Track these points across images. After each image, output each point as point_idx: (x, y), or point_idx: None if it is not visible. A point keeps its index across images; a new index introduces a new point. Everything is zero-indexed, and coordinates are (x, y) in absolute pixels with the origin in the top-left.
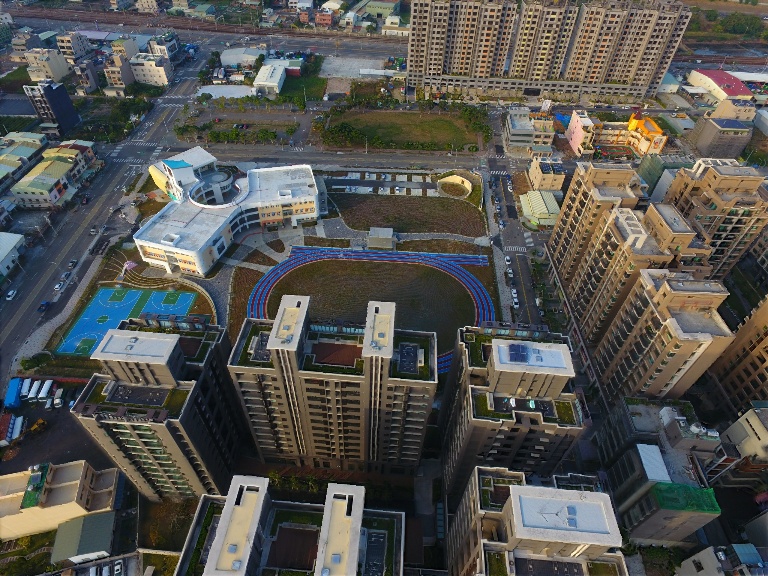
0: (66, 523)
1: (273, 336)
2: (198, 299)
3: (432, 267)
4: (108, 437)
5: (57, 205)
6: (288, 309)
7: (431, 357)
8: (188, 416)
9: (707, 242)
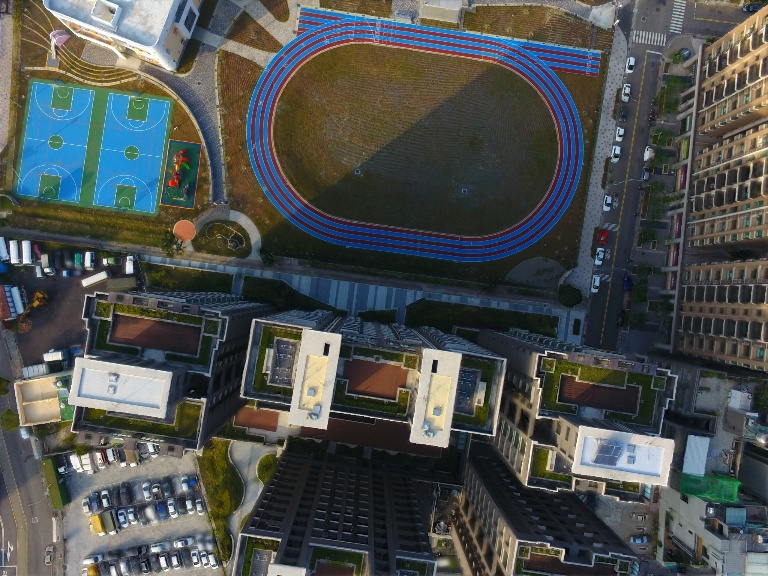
0: None
1: (295, 406)
2: (176, 113)
3: (513, 71)
4: None
5: None
6: (312, 357)
7: (493, 389)
8: (206, 429)
9: None
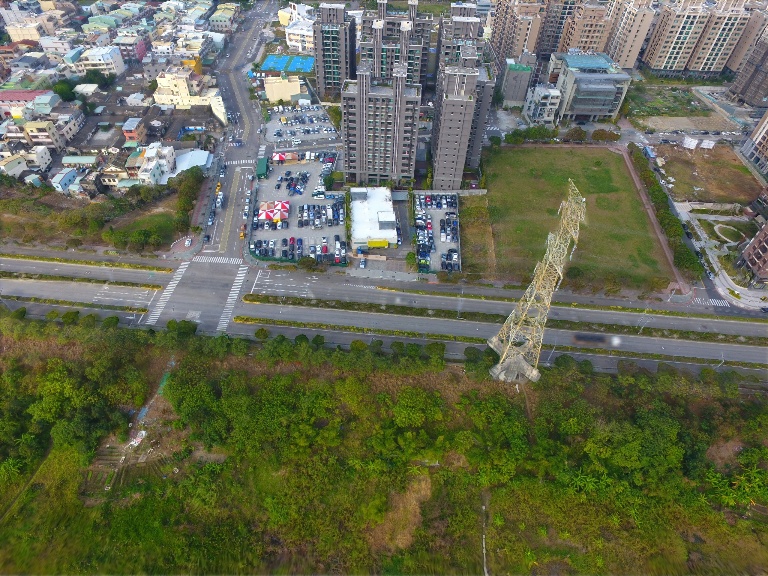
0: (293, 95)
1: (379, 0)
2: None
3: (431, 52)
4: (321, 39)
5: (231, 30)
6: None
7: None
8: None
9: (545, 3)
